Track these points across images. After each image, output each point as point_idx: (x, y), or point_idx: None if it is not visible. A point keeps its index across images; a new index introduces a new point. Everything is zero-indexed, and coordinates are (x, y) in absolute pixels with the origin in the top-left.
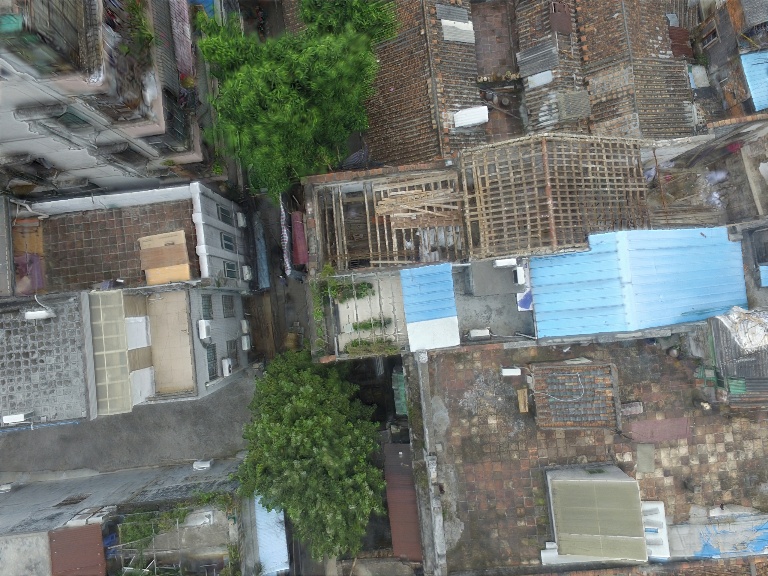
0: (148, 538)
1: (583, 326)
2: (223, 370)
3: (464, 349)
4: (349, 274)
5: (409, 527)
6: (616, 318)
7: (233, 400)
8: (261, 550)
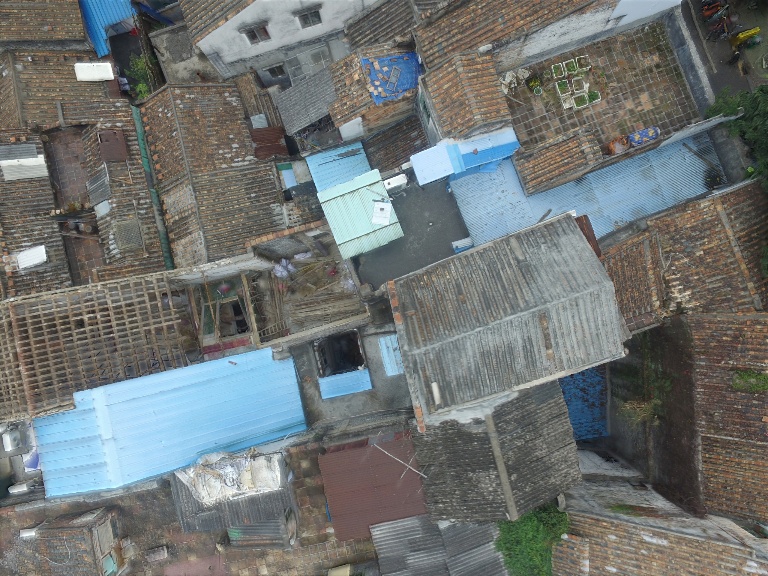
0: None
1: (78, 484)
2: None
3: None
4: None
5: None
6: (102, 475)
7: None
8: None
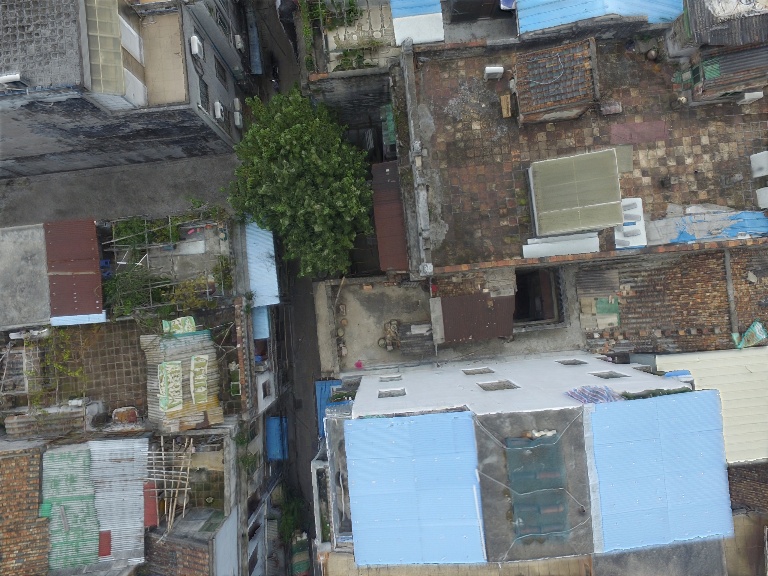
0: (141, 239)
1: (563, 16)
2: (215, 112)
3: (448, 46)
4: None
5: (396, 240)
6: (595, 4)
7: (226, 175)
8: (252, 283)
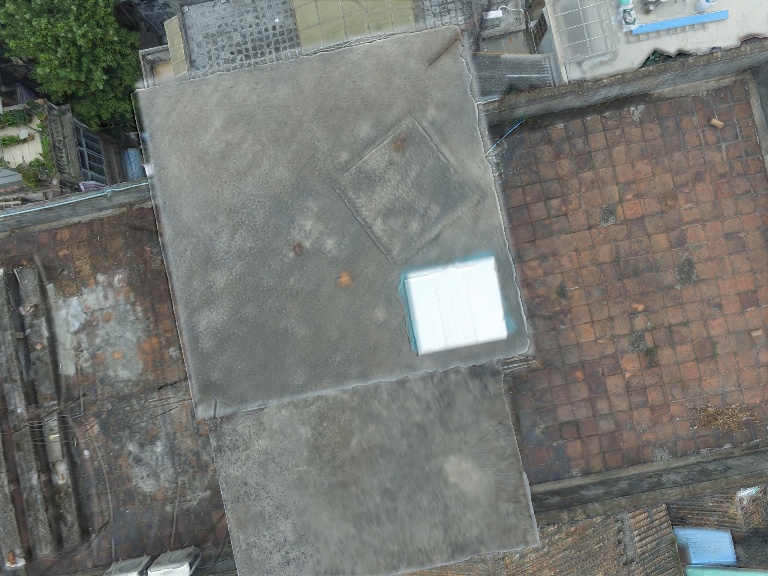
0: None
1: None
2: None
3: None
4: None
5: None
6: None
7: None
8: None
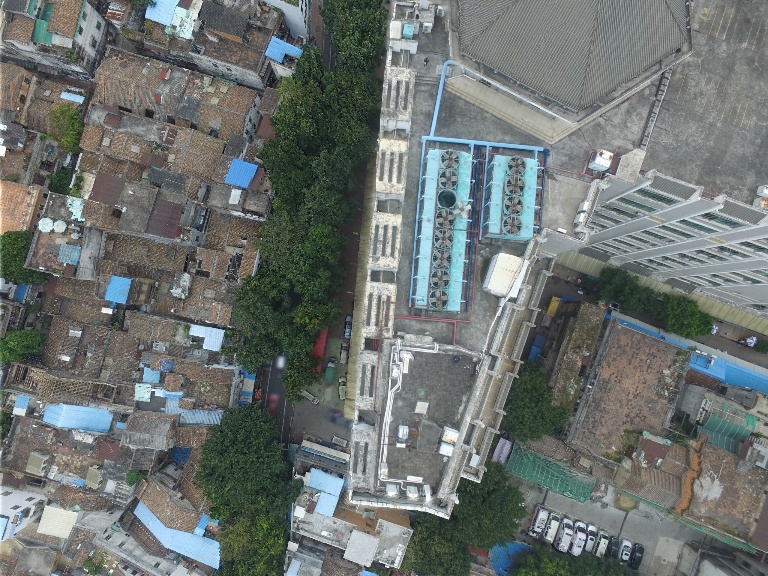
0: None
1: (51, 422)
2: None
3: (25, 417)
4: (6, 391)
5: None
6: (57, 423)
7: None
8: None
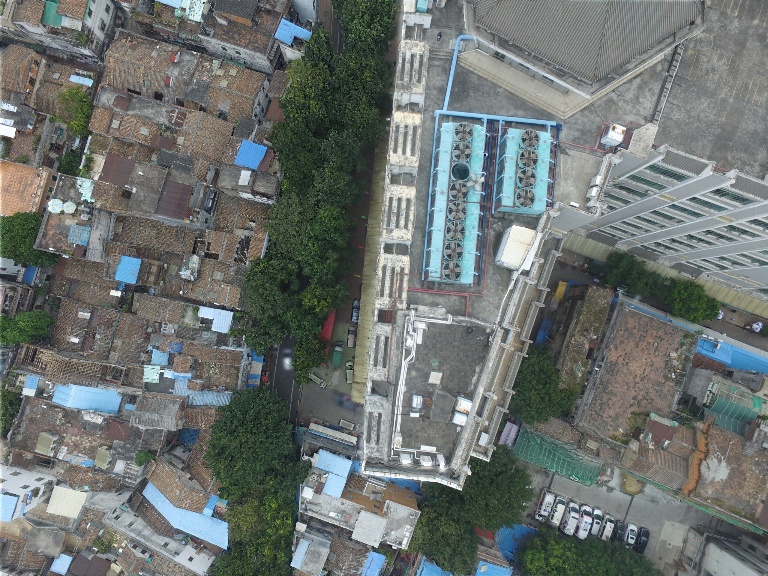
0: None
1: (60, 402)
2: None
3: None
4: (16, 372)
5: None
6: None
7: None
8: None
